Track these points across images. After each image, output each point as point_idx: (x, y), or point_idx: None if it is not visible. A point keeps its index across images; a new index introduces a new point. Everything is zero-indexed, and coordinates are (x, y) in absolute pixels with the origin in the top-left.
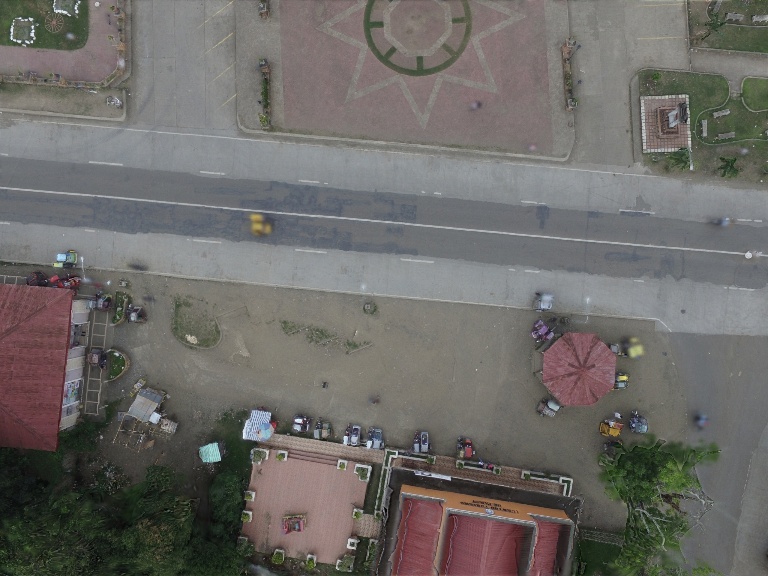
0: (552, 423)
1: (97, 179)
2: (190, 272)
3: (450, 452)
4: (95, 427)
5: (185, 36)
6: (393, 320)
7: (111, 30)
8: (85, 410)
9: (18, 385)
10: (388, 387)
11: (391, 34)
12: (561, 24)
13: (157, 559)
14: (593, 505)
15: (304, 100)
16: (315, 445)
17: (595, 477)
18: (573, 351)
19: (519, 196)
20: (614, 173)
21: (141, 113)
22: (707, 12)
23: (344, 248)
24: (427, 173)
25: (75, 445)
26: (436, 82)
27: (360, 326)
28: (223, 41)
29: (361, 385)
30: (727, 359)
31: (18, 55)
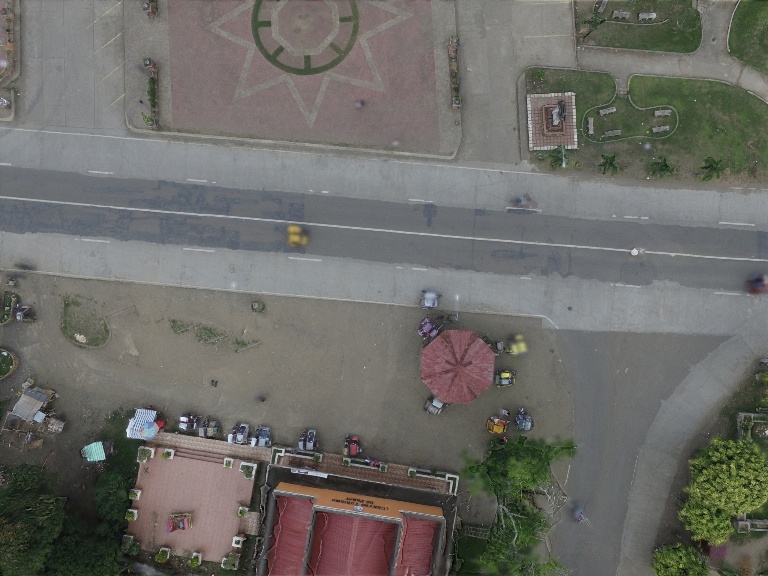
0: (440, 420)
1: None
2: (78, 271)
3: (338, 450)
4: None
5: (74, 36)
6: (281, 318)
7: (0, 30)
8: None
9: None
10: (277, 385)
11: (279, 33)
12: (448, 23)
13: (9, 557)
14: (480, 502)
15: (192, 99)
16: (203, 443)
17: (481, 474)
18: (451, 348)
19: (406, 194)
20: (501, 171)
21: (30, 113)
22: (594, 10)
23: (232, 247)
24: (315, 172)
25: None
26: (323, 81)
27: (248, 324)
28: (112, 41)
29: (250, 383)
30: (614, 356)
31: None
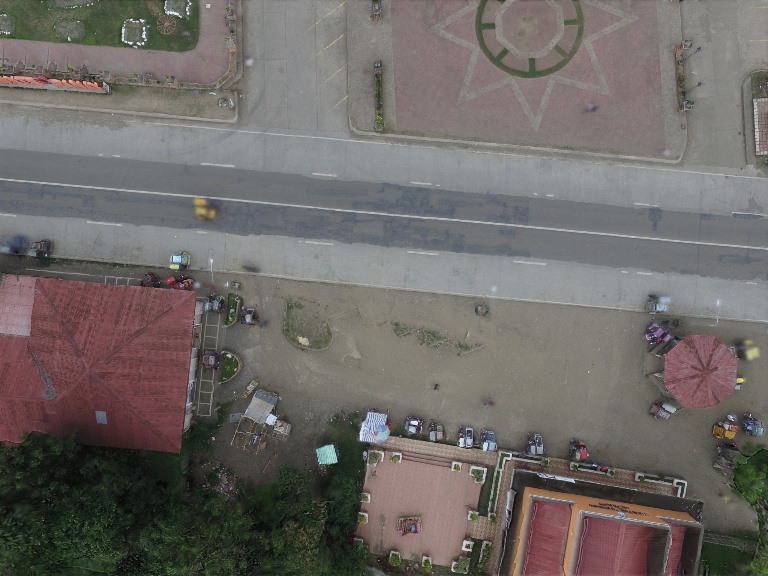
0: (664, 425)
1: (209, 181)
2: (302, 274)
3: (562, 454)
4: (207, 429)
5: (296, 38)
6: (505, 322)
7: (222, 32)
8: (198, 412)
9: (146, 387)
10: (499, 389)
11: (503, 36)
12: (673, 26)
13: (307, 561)
14: (706, 507)
15: (416, 102)
16: (427, 447)
17: (709, 479)
18: (695, 354)
19: (631, 198)
20: (726, 175)
21: (252, 115)
22: None
23: (456, 250)
24: (539, 175)
25: (191, 447)
26: (548, 84)
27: (472, 328)
28: (334, 43)
29: (472, 387)
30: None
31: (129, 57)
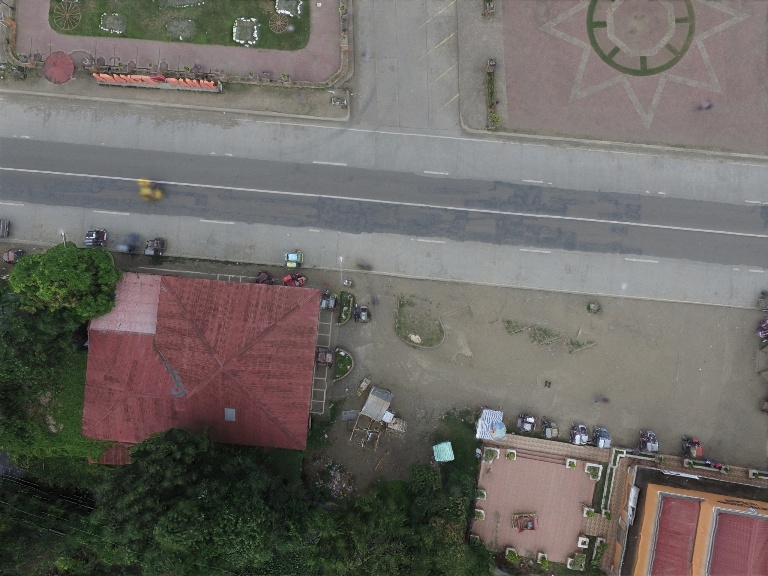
0: None
1: (321, 179)
2: (414, 272)
3: (674, 451)
4: (320, 426)
5: (406, 36)
6: (616, 320)
7: (332, 30)
8: (311, 409)
9: (274, 384)
10: (611, 386)
11: (614, 34)
12: None
13: (457, 557)
14: None
15: (528, 100)
16: (540, 444)
17: None
18: None
19: (743, 196)
20: None
21: (364, 113)
22: None
23: (568, 248)
24: (651, 173)
25: None
26: (660, 82)
27: (584, 326)
28: (445, 41)
29: (584, 384)
30: None
31: (240, 55)
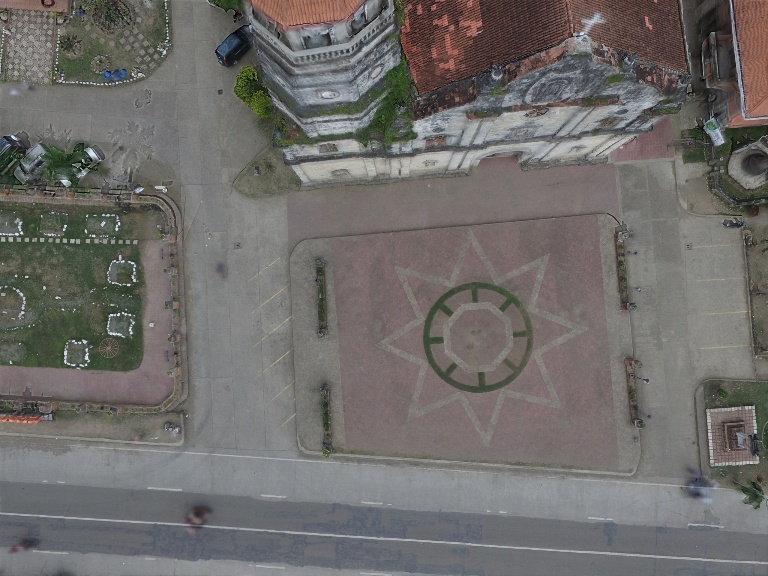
0: None
1: (156, 505)
2: None
3: None
4: None
5: (242, 354)
6: None
7: (166, 350)
8: None
9: None
10: None
11: (452, 350)
12: (624, 336)
13: None
14: None
15: (365, 420)
16: None
17: None
18: None
19: (586, 512)
20: (681, 486)
21: (199, 435)
22: None
23: (410, 570)
24: (492, 491)
25: None
26: (499, 398)
27: None
28: (281, 359)
29: None
30: None
31: (72, 378)
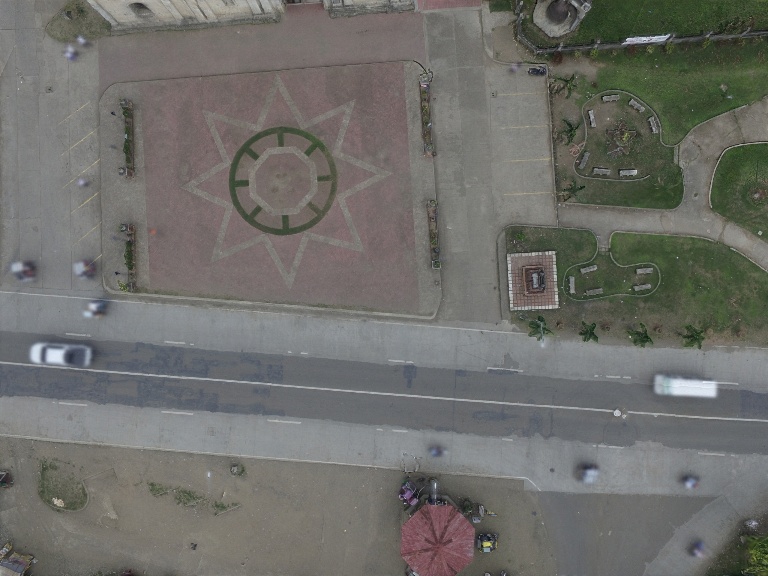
0: None
1: None
2: (56, 435)
3: None
4: None
5: (51, 196)
6: (261, 481)
7: None
8: None
9: None
10: (257, 548)
11: (256, 193)
12: (427, 181)
13: None
14: None
15: (169, 260)
16: None
17: None
18: (430, 525)
19: (386, 355)
20: (482, 330)
21: (6, 274)
22: (574, 166)
23: (211, 409)
24: (294, 333)
25: None
26: (302, 241)
27: (228, 487)
28: (89, 201)
29: (230, 547)
30: (597, 518)
31: None
